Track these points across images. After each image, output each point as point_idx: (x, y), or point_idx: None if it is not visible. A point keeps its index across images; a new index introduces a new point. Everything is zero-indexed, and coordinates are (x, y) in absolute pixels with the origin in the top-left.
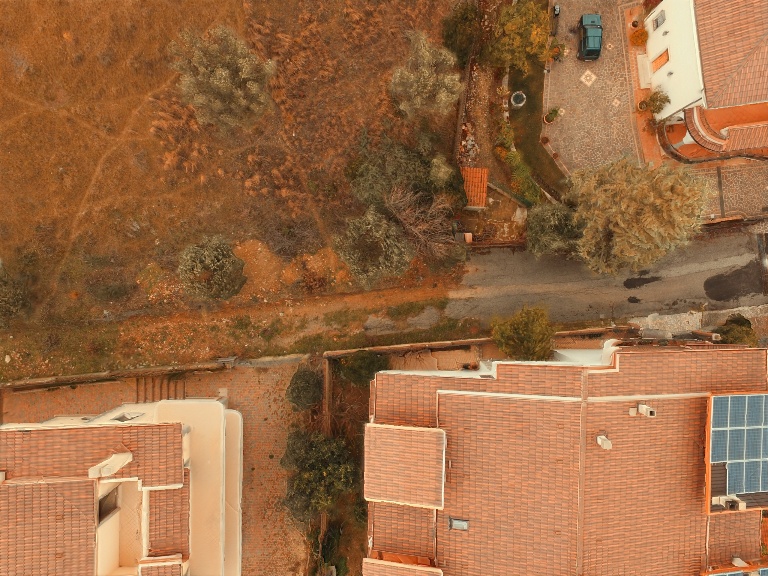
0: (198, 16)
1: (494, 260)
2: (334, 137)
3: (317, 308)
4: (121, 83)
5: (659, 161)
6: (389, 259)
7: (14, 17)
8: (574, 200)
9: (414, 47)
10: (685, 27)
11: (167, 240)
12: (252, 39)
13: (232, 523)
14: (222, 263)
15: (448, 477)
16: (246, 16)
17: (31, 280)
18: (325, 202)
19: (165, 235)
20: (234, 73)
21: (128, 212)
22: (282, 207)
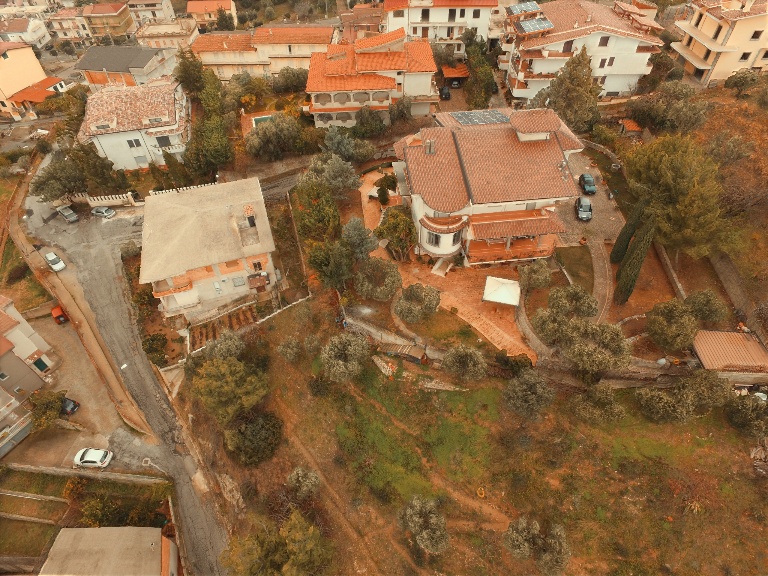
0: None
1: None
2: None
3: None
4: None
5: None
6: None
7: None
8: None
9: None
10: None
11: None
12: None
13: None
14: None
15: (629, 25)
16: None
17: None
18: None
19: None
20: None
21: None
22: None
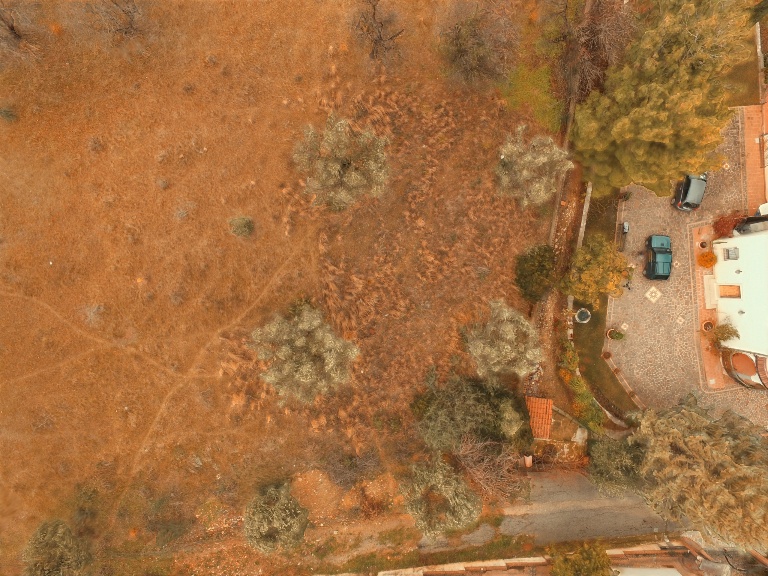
0: (272, 255)
1: (551, 476)
2: (402, 374)
3: (372, 526)
4: (191, 320)
5: (721, 379)
6: (457, 515)
7: (87, 254)
8: (641, 442)
9: (494, 311)
10: (763, 281)
11: (229, 475)
12: (326, 280)
13: None
14: (290, 525)
15: None
16: (321, 257)
17: (89, 517)
18: (389, 433)
19: (227, 470)
20: (320, 367)
21: (191, 448)
22: (345, 438)
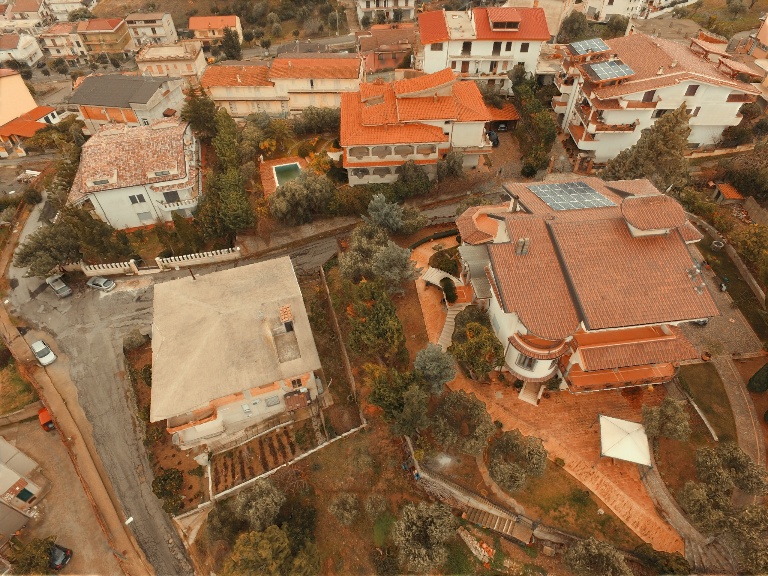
0: None
1: None
2: None
3: None
4: None
5: None
6: None
7: None
8: None
9: None
10: None
11: None
12: None
13: (766, 94)
14: None
15: None
16: None
17: None
18: None
19: None
20: None
21: None
22: None
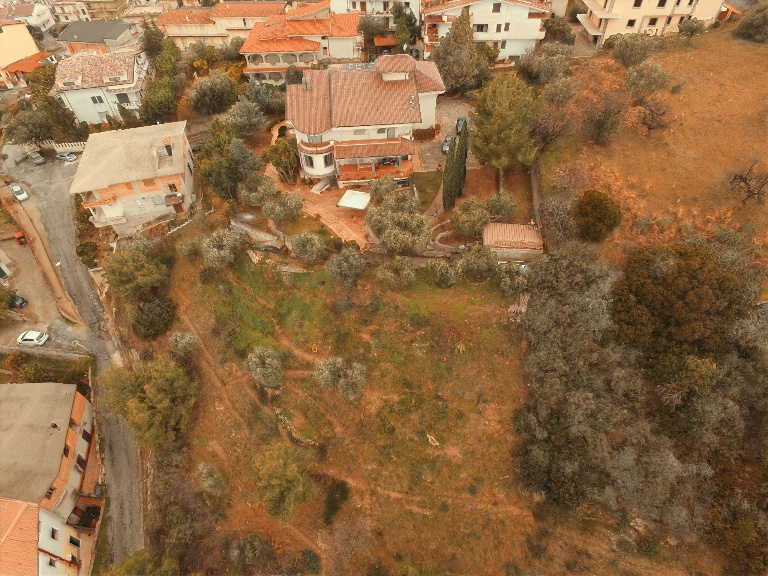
0: None
1: None
2: None
3: None
4: None
5: None
6: None
7: None
8: None
9: None
10: None
11: None
12: None
13: None
14: None
15: None
16: None
17: None
18: None
19: None
20: None
21: None
22: None
